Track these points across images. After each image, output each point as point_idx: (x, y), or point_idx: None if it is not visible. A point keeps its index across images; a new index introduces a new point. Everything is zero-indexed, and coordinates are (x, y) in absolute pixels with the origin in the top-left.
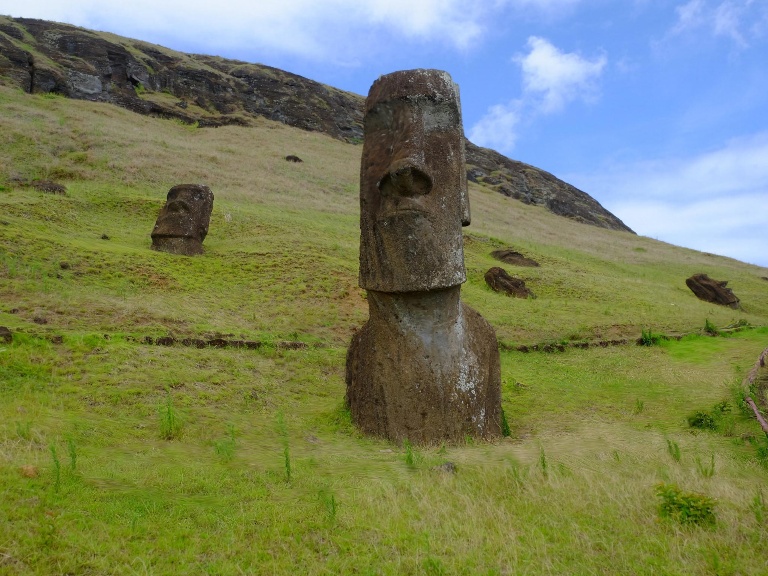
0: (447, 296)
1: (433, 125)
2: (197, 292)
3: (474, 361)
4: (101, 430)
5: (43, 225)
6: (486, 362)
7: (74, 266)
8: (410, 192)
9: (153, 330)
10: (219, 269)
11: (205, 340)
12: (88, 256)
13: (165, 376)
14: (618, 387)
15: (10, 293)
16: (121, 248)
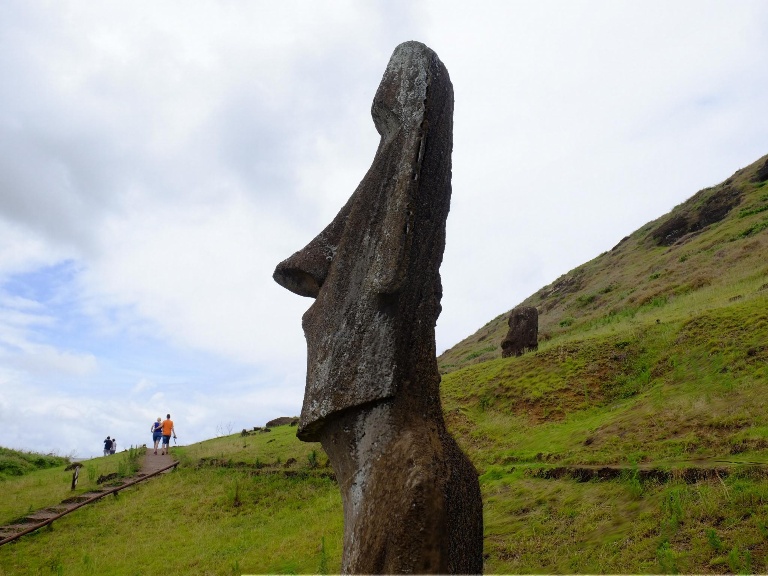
0: (329, 441)
1: None
2: None
3: (354, 560)
4: (283, 575)
5: None
6: (367, 565)
7: (765, 349)
8: (313, 294)
9: (674, 445)
10: None
11: (598, 469)
12: None
13: None
14: None
15: (640, 405)
16: None
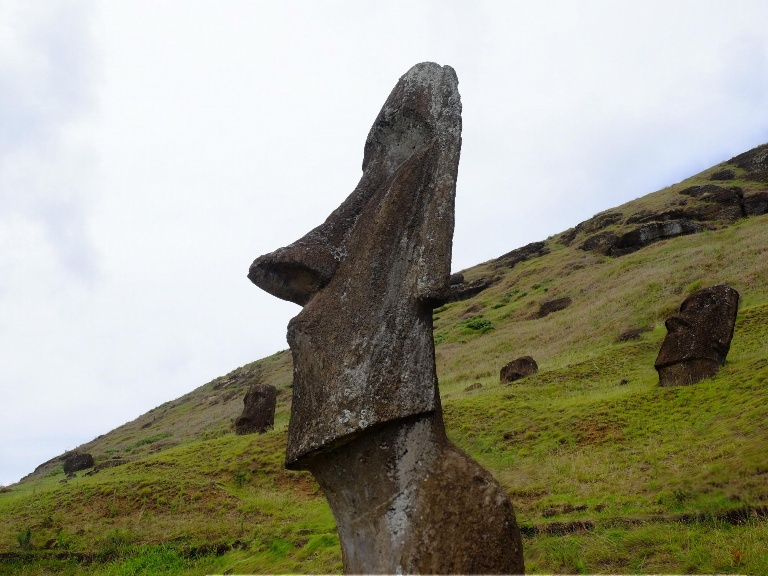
0: (352, 460)
1: (409, 156)
2: (640, 439)
3: None
4: None
5: (561, 387)
6: None
7: (518, 434)
8: (300, 296)
9: None
10: (710, 395)
11: None
12: (545, 417)
13: None
14: None
15: None
16: (608, 395)
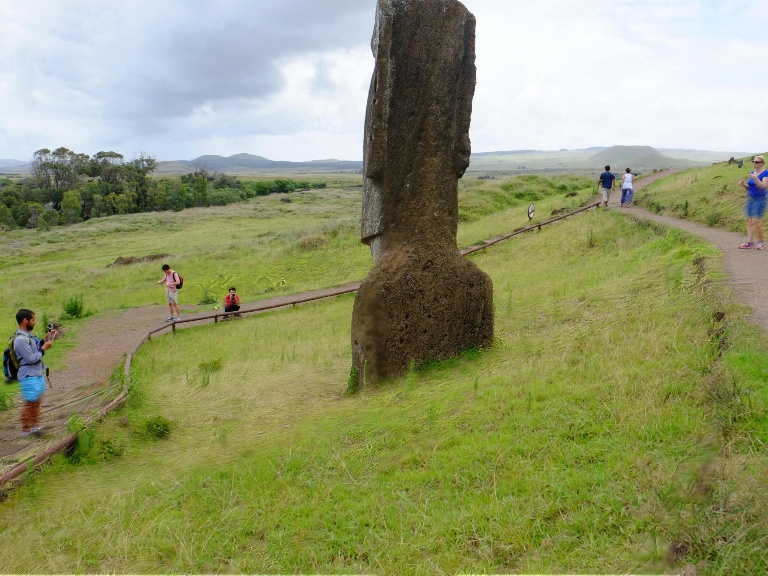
0: None
1: None
2: None
3: None
4: None
5: None
6: None
7: None
8: None
9: None
10: None
11: None
12: None
13: (594, 291)
14: (250, 456)
15: None
16: None
